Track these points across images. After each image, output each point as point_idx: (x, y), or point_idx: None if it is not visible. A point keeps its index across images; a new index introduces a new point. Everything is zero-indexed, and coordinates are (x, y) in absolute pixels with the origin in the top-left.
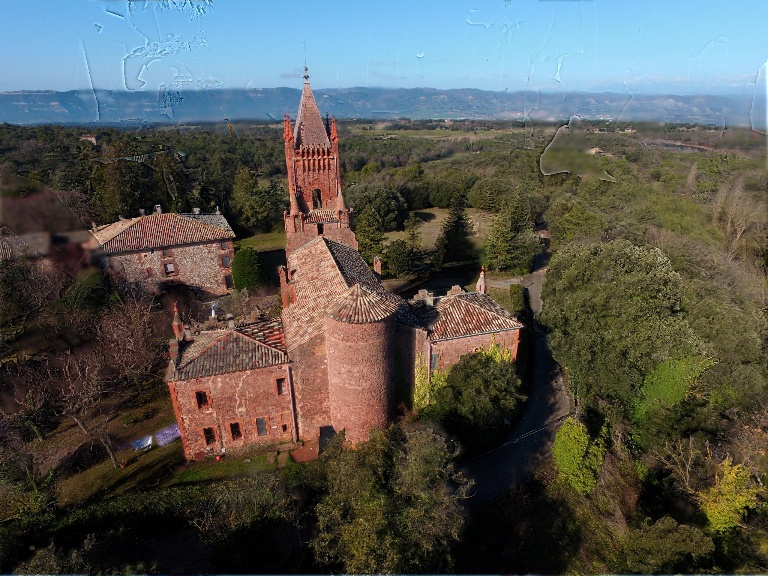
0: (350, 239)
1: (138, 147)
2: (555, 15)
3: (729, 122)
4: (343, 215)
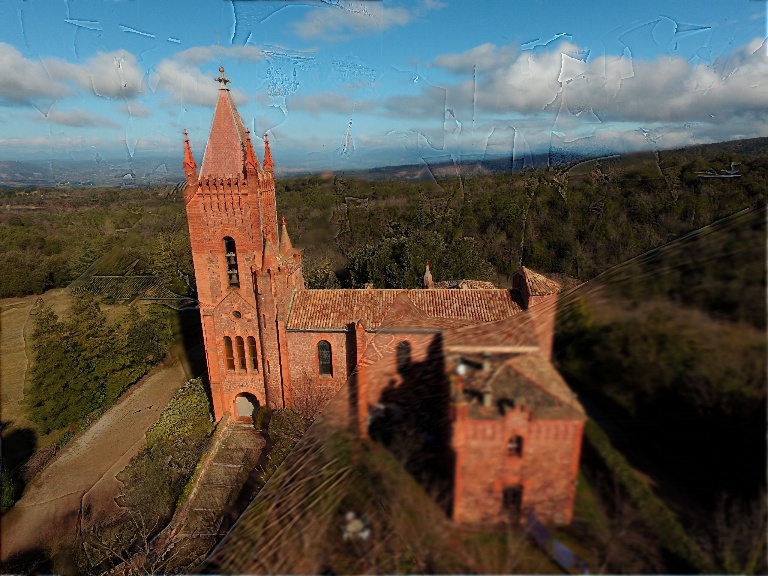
0: (302, 286)
1: None
2: (141, 57)
3: None
4: (299, 257)
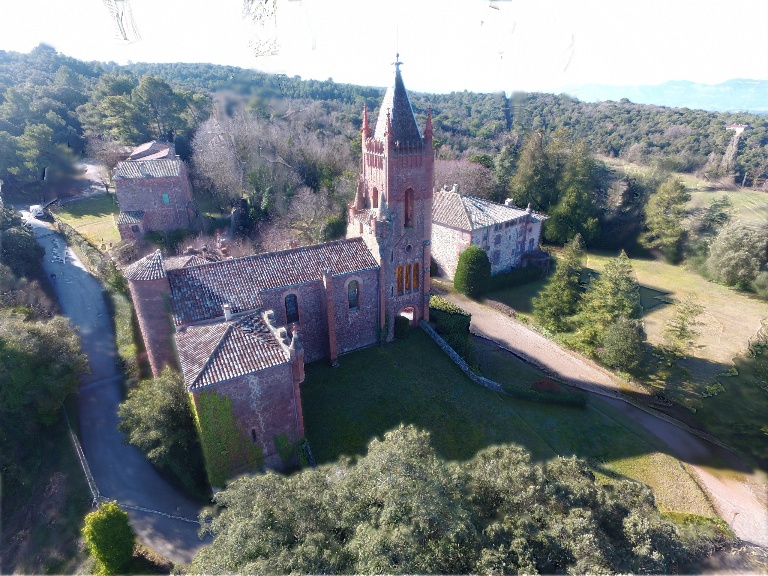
0: (376, 250)
1: (574, 135)
2: None
3: None
4: None
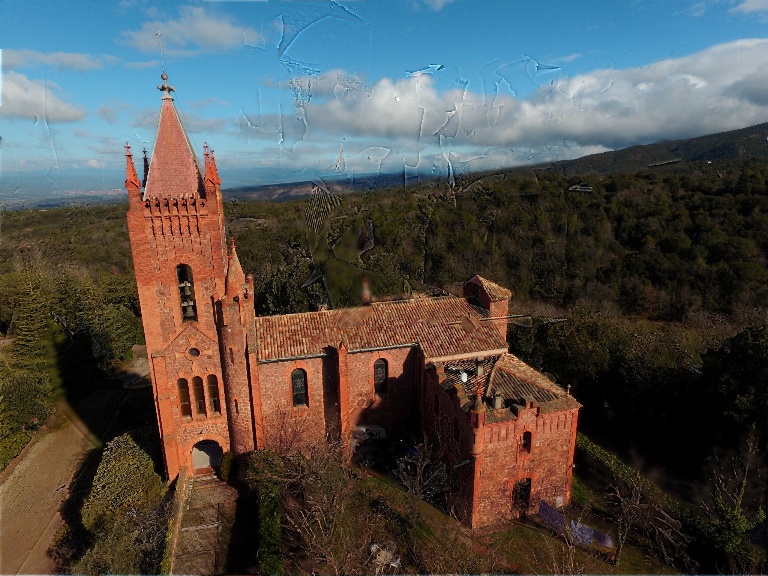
0: None
1: None
2: None
3: (230, 176)
4: None
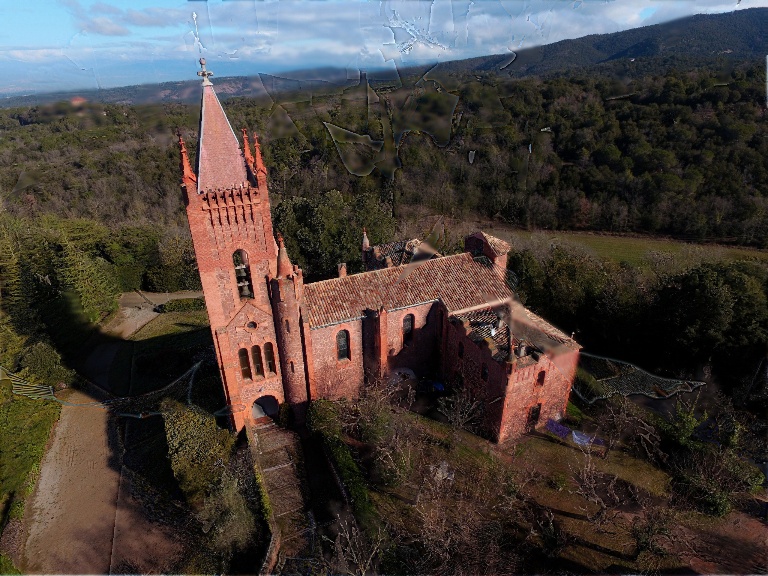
0: None
1: None
2: None
3: (186, 107)
4: None
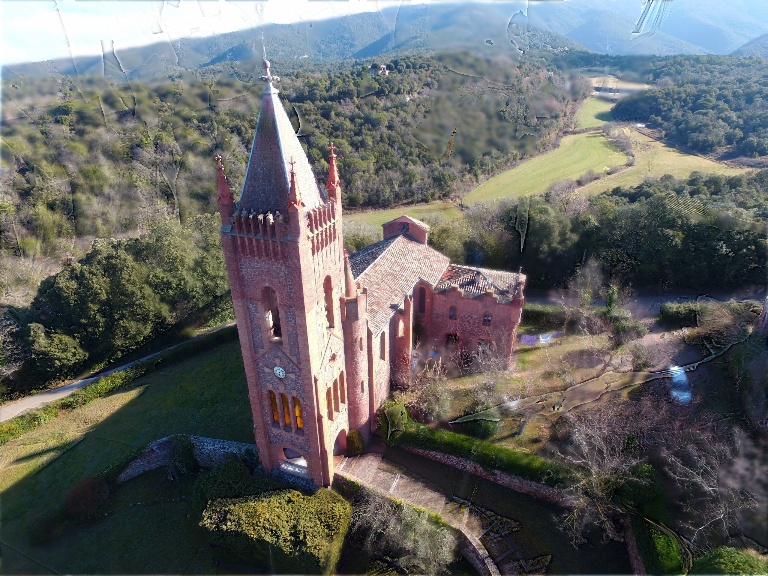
0: None
1: None
2: None
3: None
4: None
